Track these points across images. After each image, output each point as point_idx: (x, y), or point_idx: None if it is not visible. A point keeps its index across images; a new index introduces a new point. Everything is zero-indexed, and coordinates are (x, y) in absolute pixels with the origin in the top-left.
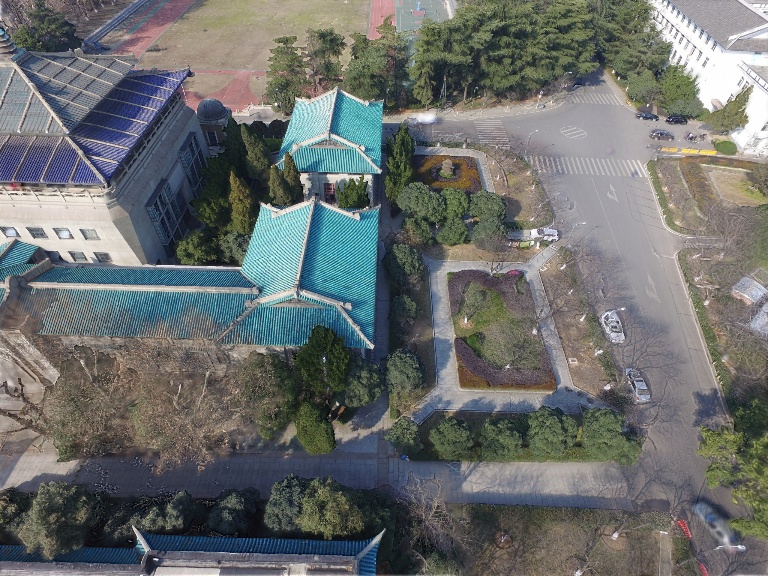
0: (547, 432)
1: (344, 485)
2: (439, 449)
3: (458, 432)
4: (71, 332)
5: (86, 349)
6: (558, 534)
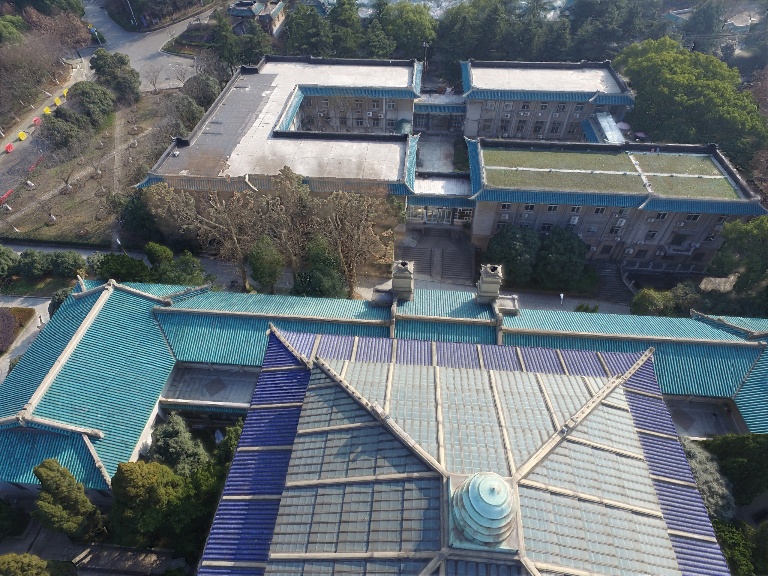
0: (1, 247)
1: (152, 229)
2: (84, 259)
3: (62, 252)
4: (337, 300)
5: (316, 281)
6: (49, 234)
